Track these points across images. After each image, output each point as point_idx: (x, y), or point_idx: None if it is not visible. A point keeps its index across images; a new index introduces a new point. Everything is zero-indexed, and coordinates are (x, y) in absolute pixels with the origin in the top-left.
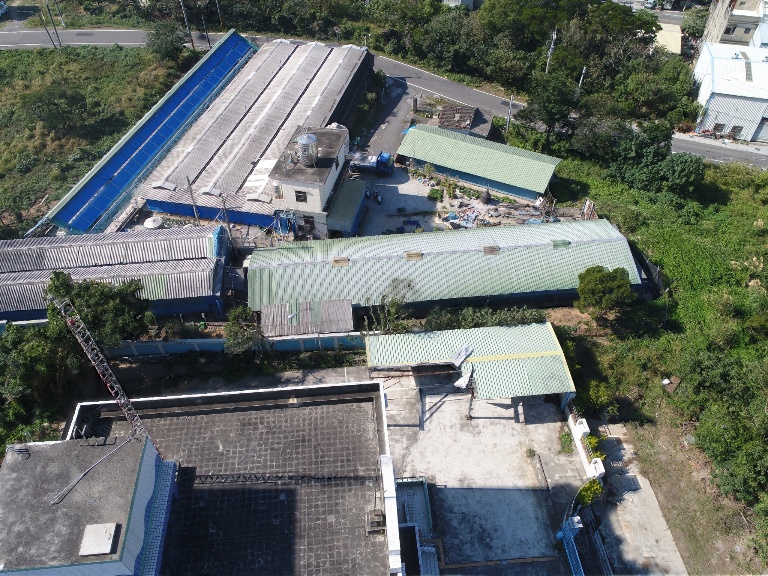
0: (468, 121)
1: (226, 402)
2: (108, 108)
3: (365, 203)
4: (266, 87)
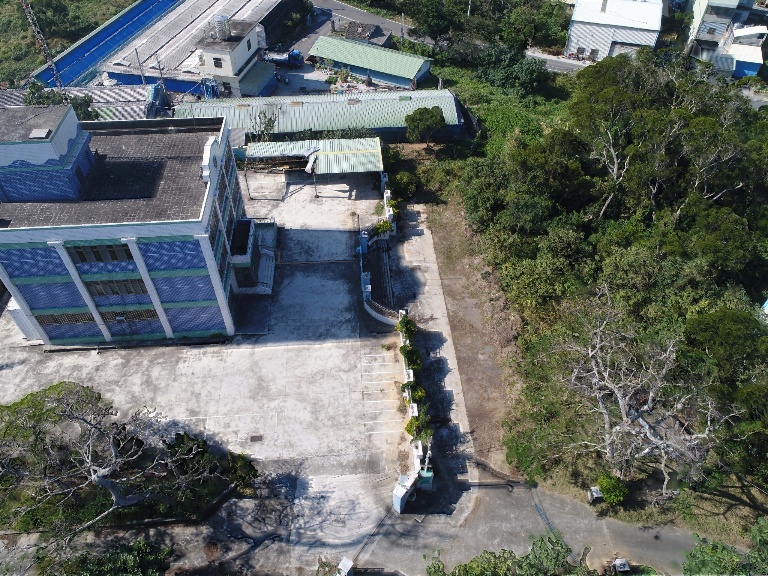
0: (368, 33)
1: (130, 128)
2: None
3: (275, 83)
4: (211, 6)
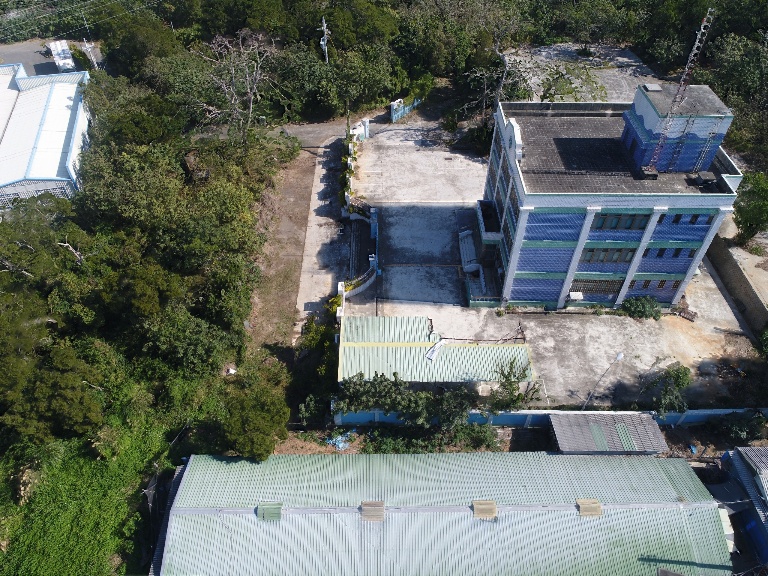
0: None
1: None
2: None
3: None
4: None
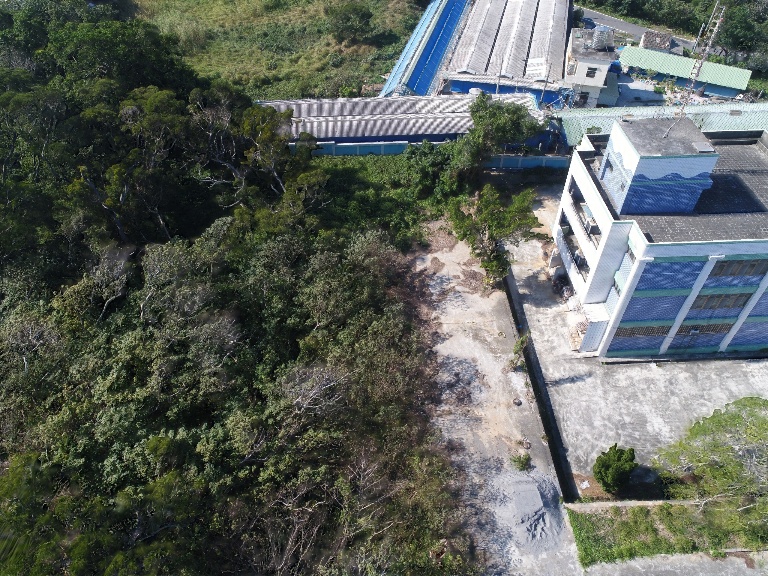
0: (668, 43)
1: None
2: (378, 27)
3: None
4: (503, 14)
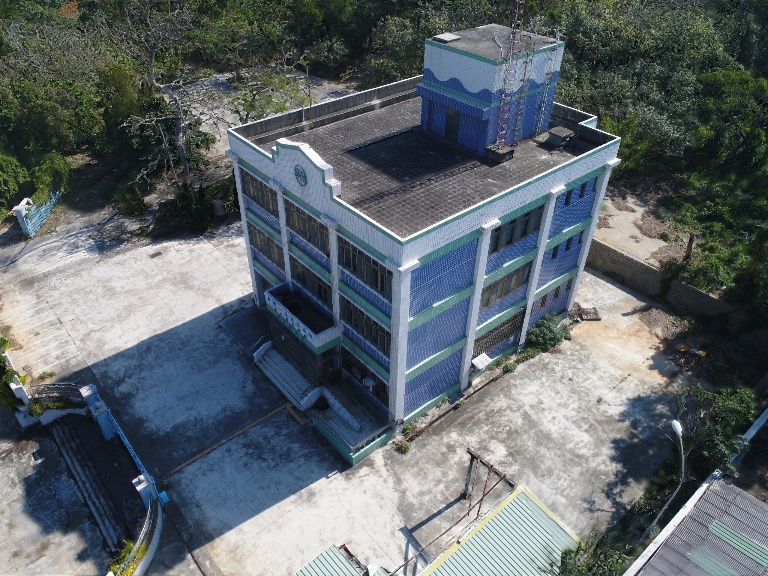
0: None
1: None
2: None
3: None
4: None
